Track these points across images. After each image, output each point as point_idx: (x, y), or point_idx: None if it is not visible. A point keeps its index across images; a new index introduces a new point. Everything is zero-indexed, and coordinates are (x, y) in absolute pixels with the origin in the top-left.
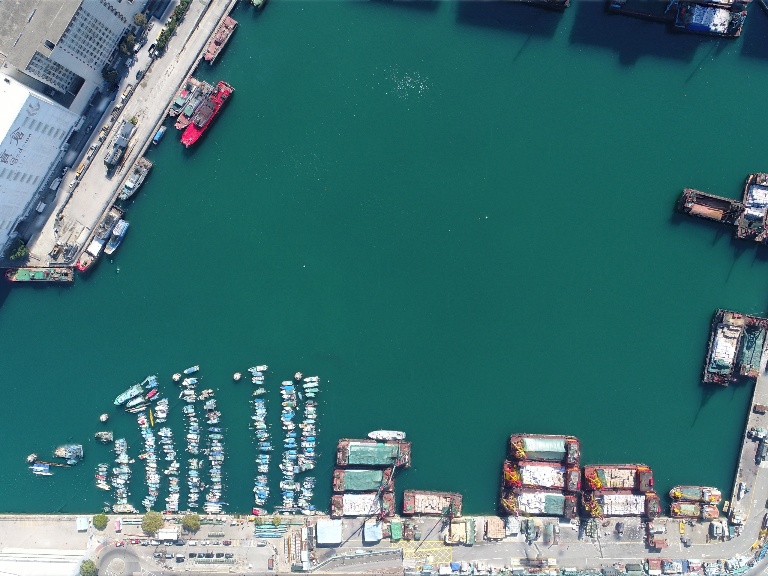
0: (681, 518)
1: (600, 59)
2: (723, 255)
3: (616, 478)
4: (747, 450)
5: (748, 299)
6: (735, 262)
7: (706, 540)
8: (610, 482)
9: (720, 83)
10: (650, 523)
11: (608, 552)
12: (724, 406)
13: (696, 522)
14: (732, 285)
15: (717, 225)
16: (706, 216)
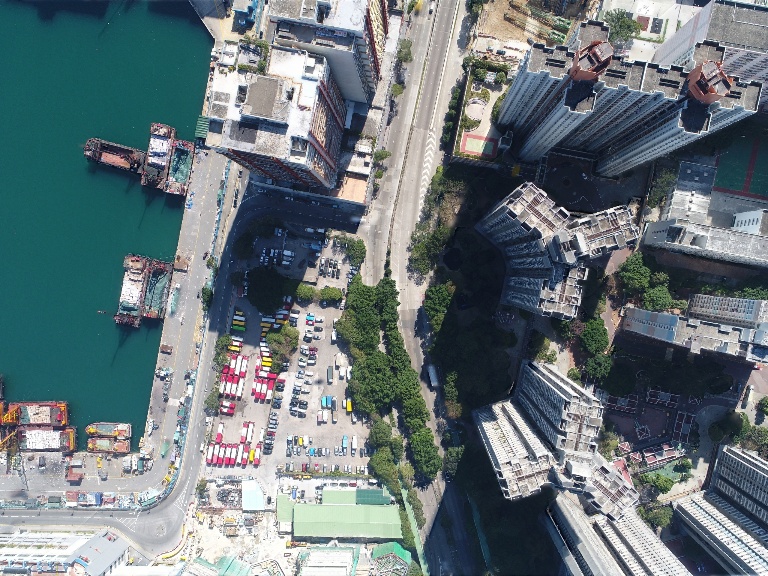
0: (98, 453)
1: (17, 14)
2: (136, 202)
3: (39, 414)
4: (156, 388)
5: (157, 244)
6: (146, 209)
7: (121, 474)
8: (32, 418)
9: (127, 37)
10: (66, 457)
11: (33, 485)
12: (139, 347)
13: (112, 457)
14: (144, 231)
15: (126, 173)
16: (118, 165)
